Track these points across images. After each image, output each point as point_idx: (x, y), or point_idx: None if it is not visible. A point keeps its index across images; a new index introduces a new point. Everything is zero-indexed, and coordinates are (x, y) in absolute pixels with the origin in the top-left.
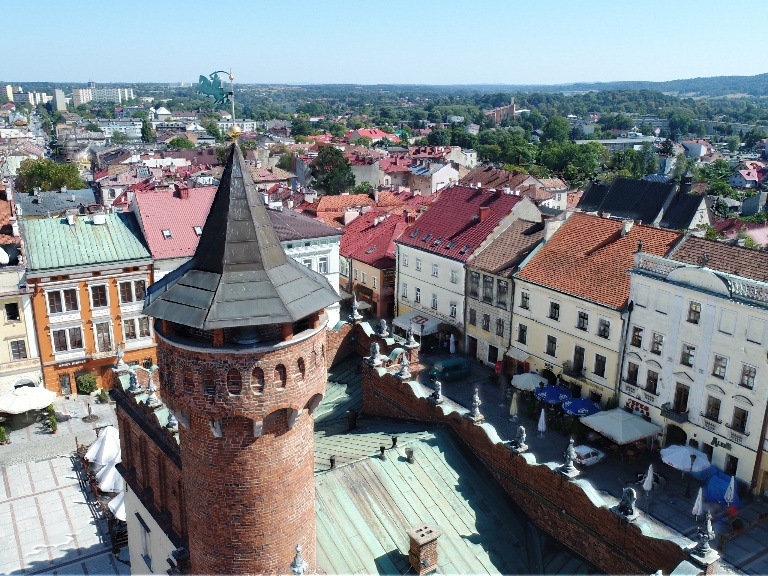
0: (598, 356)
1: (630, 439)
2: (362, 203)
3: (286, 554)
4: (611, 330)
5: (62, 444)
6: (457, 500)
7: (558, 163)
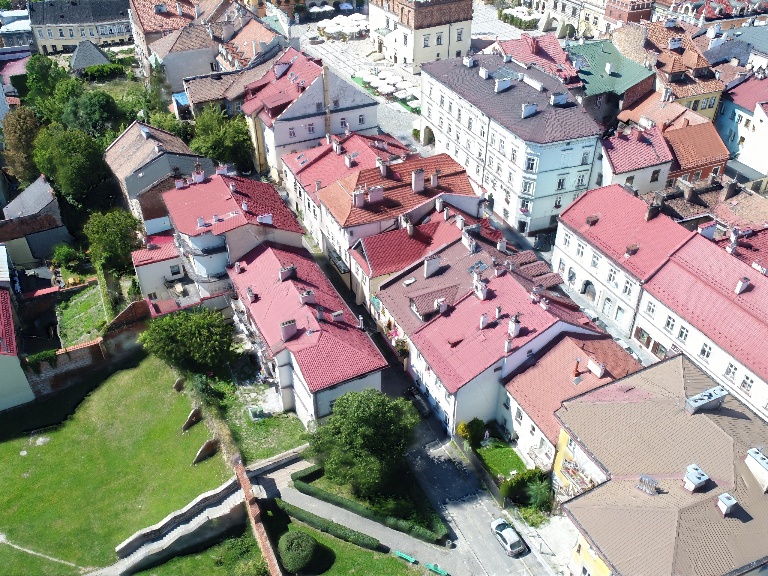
0: None
1: None
2: None
3: None
4: None
5: None
6: None
7: None
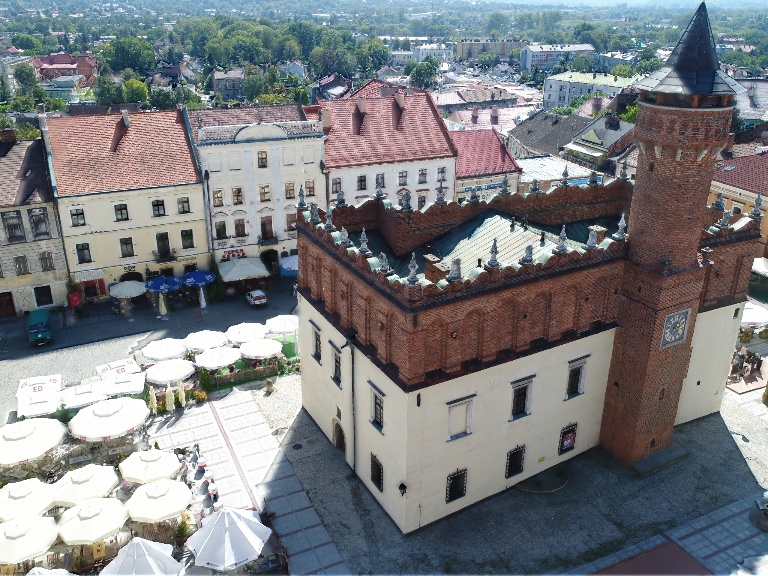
0: (182, 232)
1: None
2: None
3: None
4: (192, 203)
5: None
6: None
7: None
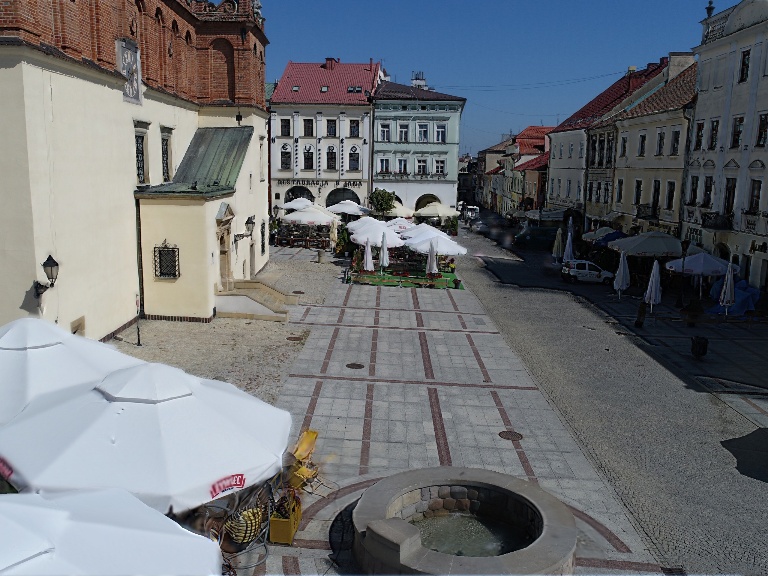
0: (671, 185)
1: (644, 251)
2: None
3: None
4: (680, 141)
5: None
6: None
7: None
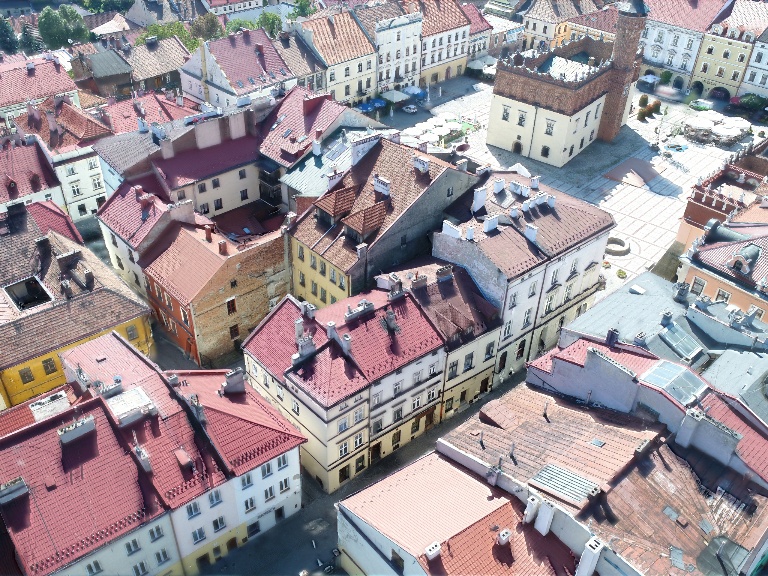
0: None
1: None
2: None
3: None
4: None
5: None
6: None
7: None
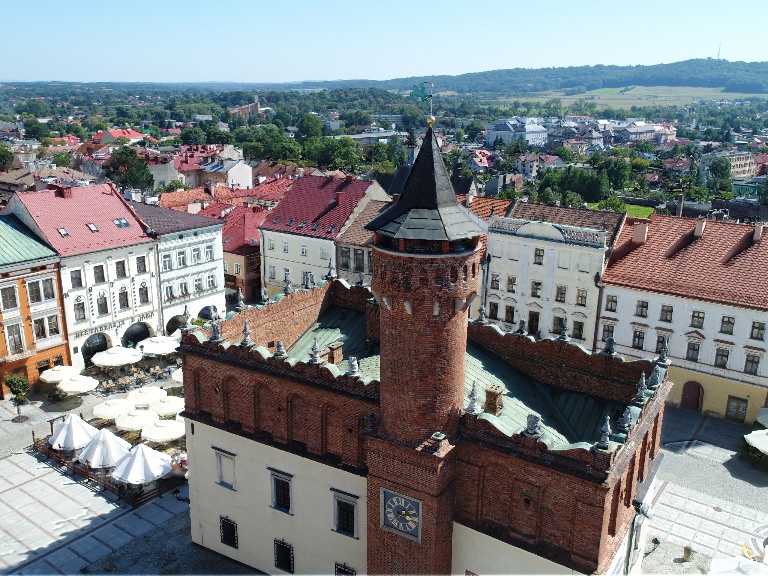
0: None
1: None
2: (200, 198)
3: (461, 393)
4: None
5: (8, 444)
6: (488, 375)
7: (321, 157)
